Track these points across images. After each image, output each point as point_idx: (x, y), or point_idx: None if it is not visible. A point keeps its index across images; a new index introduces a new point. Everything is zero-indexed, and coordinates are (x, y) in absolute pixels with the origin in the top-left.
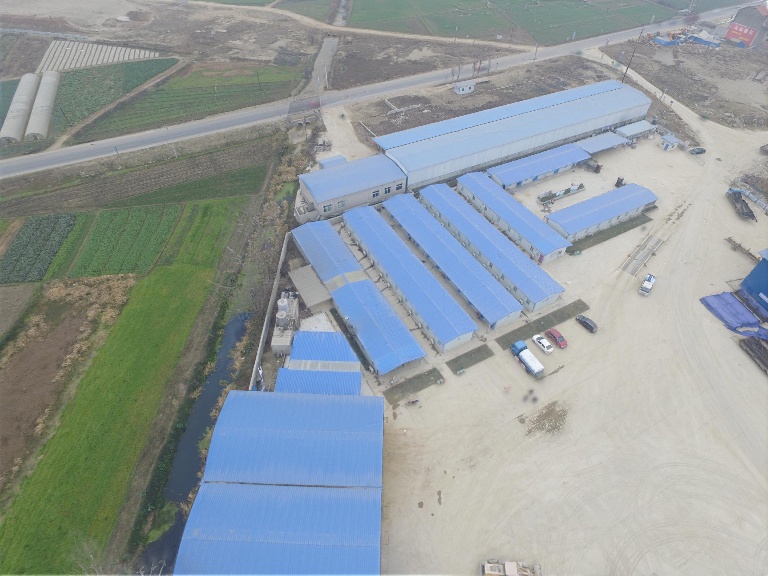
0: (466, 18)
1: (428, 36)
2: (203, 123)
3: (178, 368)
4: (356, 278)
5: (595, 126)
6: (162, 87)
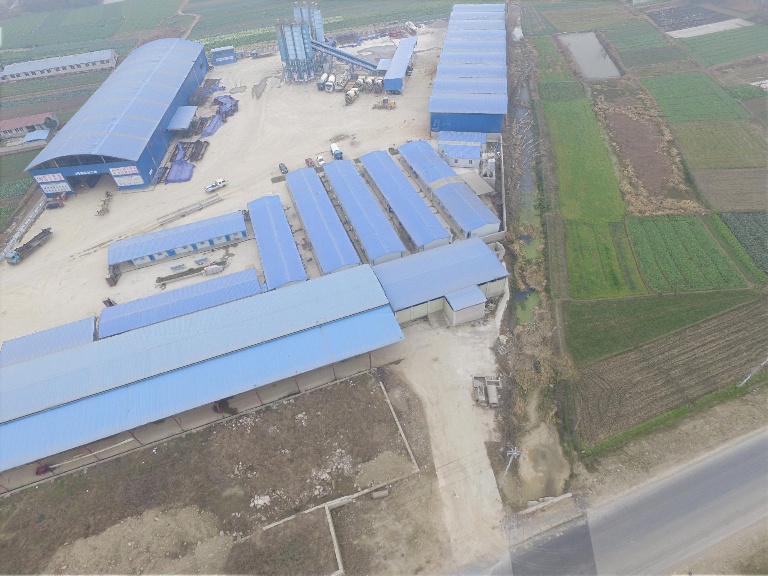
0: None
1: None
2: None
3: (553, 161)
4: (439, 182)
5: None
6: None
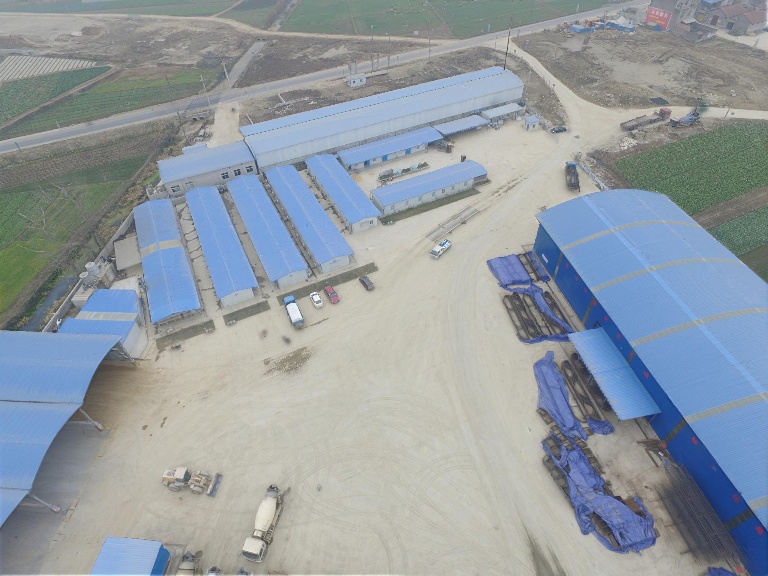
0: (396, 17)
1: (350, 35)
2: (106, 121)
3: None
4: (169, 246)
5: (462, 110)
6: (87, 92)
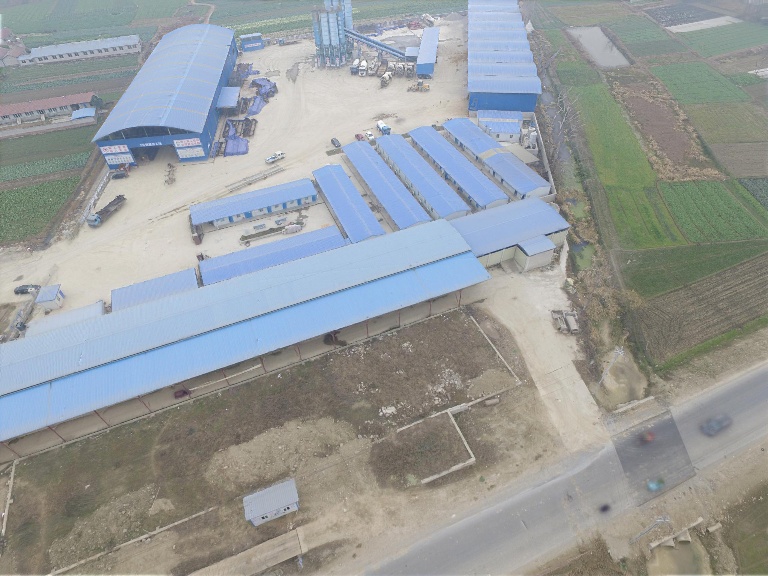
0: None
1: None
2: None
3: (584, 137)
4: (488, 153)
5: None
6: None
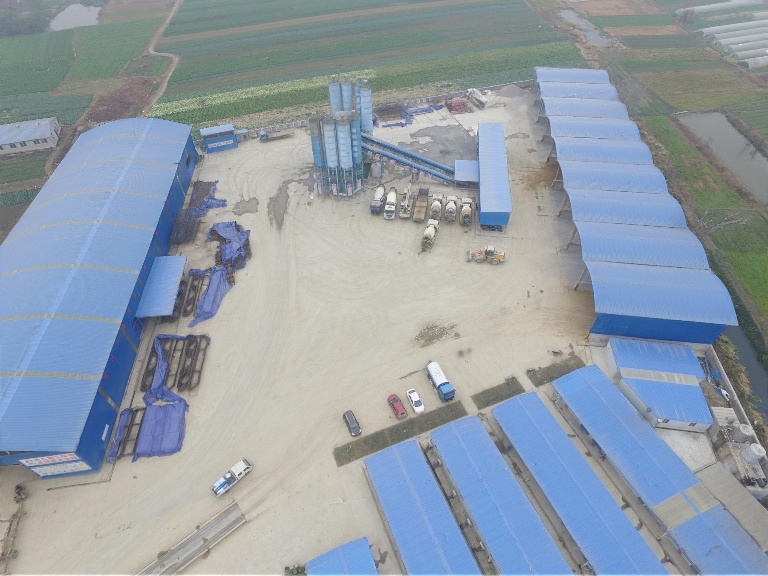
0: None
1: None
2: None
3: None
4: (673, 505)
5: None
6: None
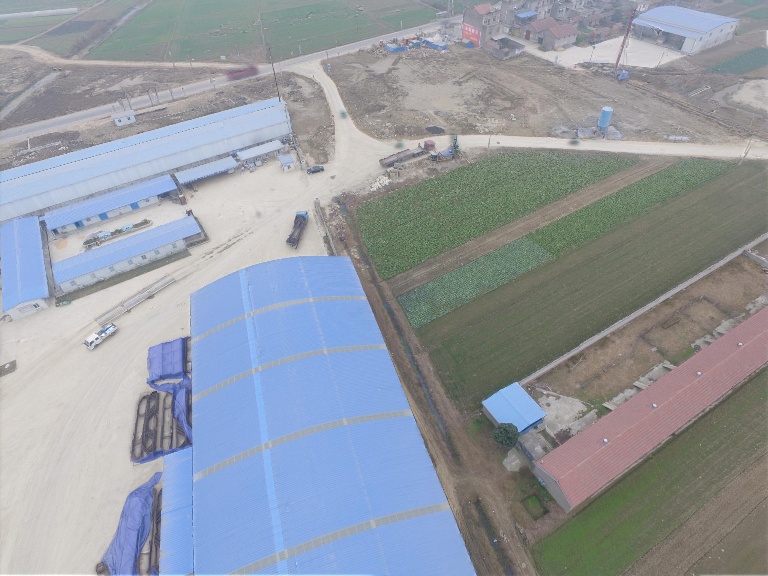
0: (217, 39)
1: (155, 62)
2: None
3: None
4: None
5: (216, 151)
6: None
